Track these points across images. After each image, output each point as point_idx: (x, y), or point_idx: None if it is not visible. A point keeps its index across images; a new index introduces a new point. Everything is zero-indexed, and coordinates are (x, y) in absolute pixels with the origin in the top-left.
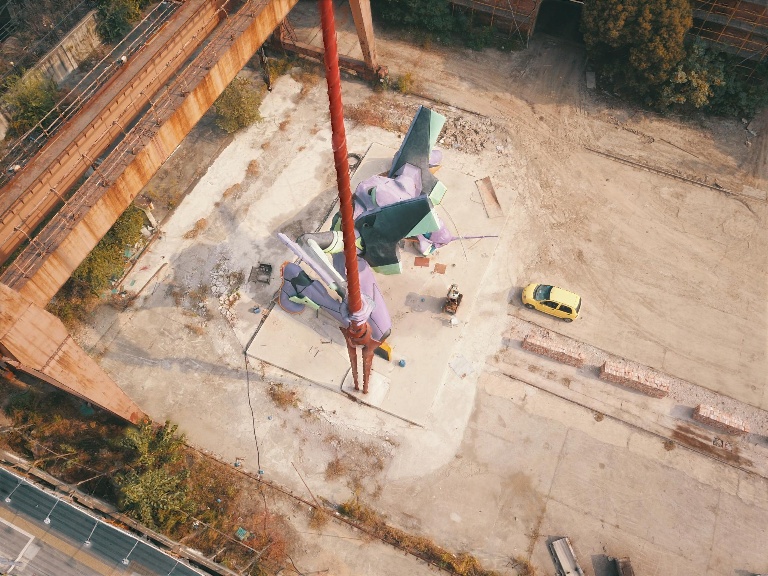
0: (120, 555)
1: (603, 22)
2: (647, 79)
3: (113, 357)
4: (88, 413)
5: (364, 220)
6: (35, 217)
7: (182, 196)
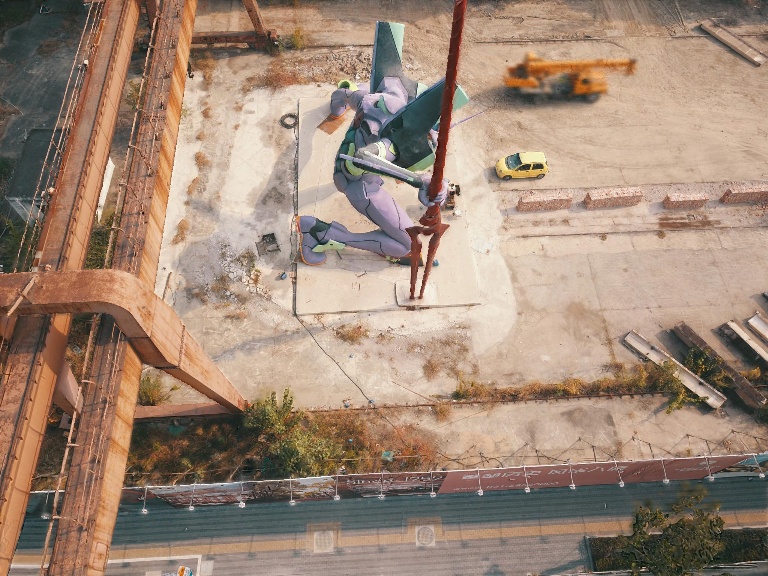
0: (293, 526)
1: None
2: None
3: None
4: (180, 431)
5: (390, 126)
6: (85, 236)
7: None
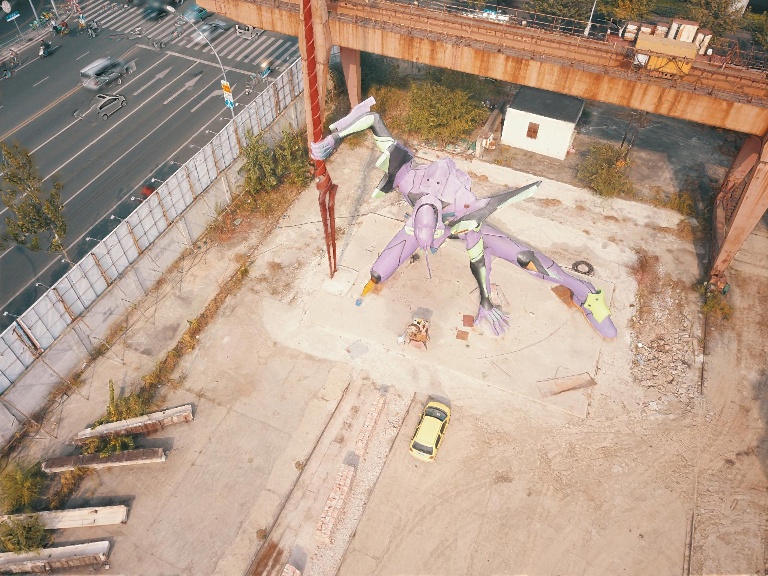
0: None
1: None
2: None
3: (366, 153)
4: None
5: None
6: None
7: (509, 167)
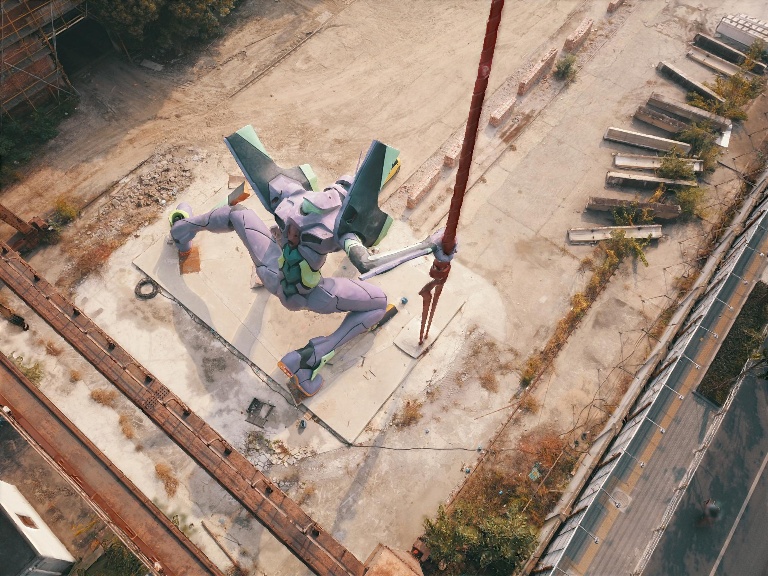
0: None
1: (136, 7)
2: (194, 20)
3: None
4: None
5: (344, 221)
6: None
7: None
